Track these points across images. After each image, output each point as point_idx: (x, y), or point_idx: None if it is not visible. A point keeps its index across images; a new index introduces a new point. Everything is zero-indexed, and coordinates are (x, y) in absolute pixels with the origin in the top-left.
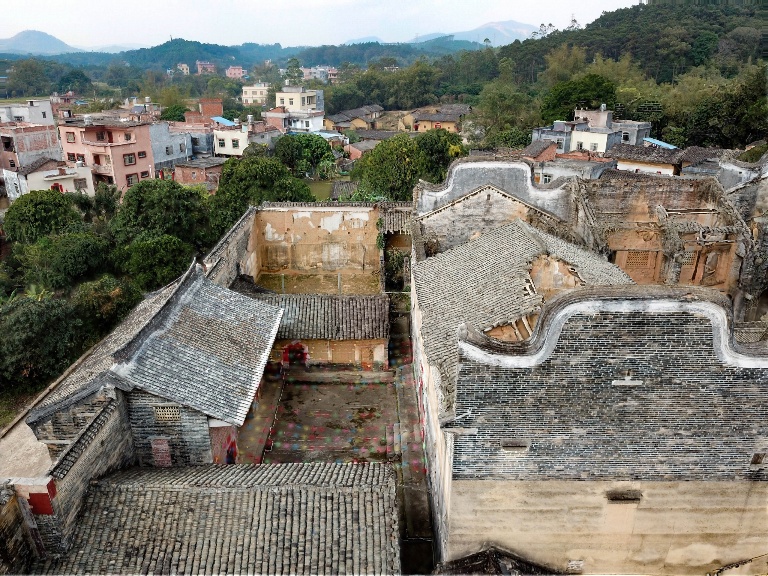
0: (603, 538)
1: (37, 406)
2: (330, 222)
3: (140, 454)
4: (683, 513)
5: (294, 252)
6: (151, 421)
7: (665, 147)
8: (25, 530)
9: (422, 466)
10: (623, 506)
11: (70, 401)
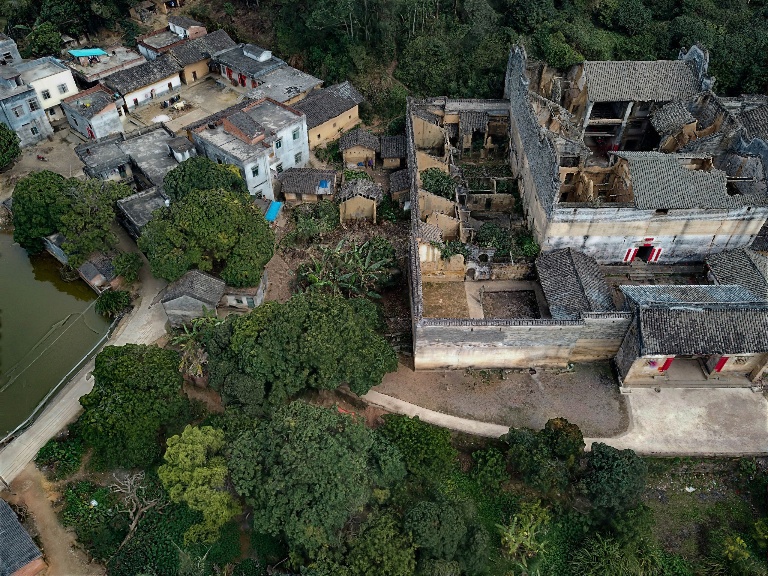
0: None
1: None
2: None
3: None
4: None
5: None
6: None
7: (102, 55)
8: None
9: (662, 266)
10: None
11: None
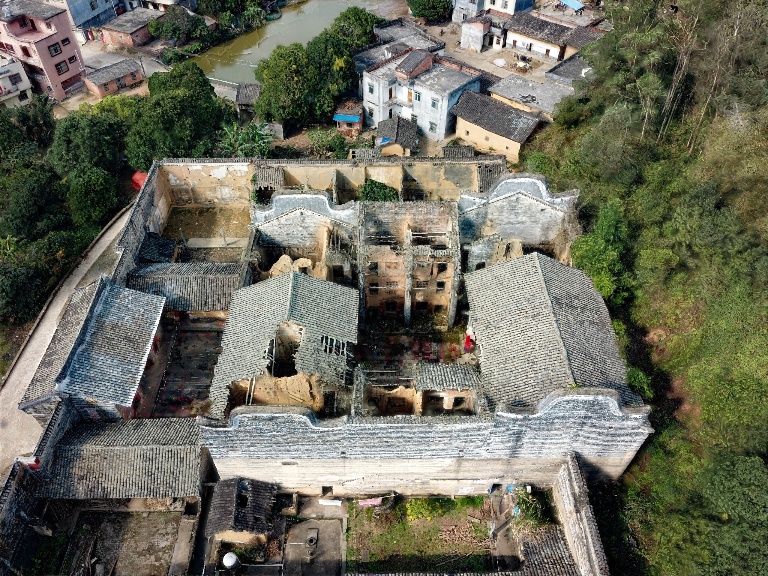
0: (287, 474)
1: (24, 350)
2: (218, 172)
3: (83, 414)
4: (318, 467)
5: (194, 192)
6: (84, 403)
7: (571, 8)
8: (30, 473)
9: None
10: (291, 466)
11: (38, 401)
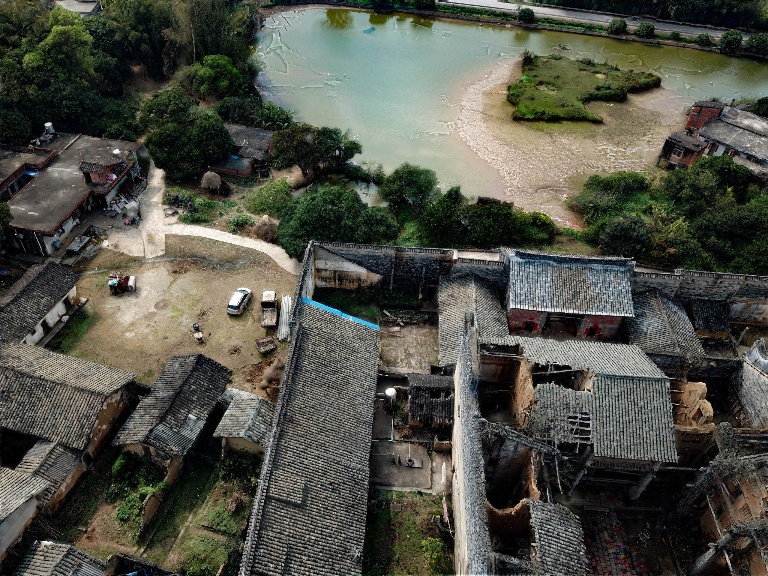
0: None
1: None
2: None
3: None
4: None
5: None
6: None
7: None
8: (451, 265)
9: None
10: None
11: None
